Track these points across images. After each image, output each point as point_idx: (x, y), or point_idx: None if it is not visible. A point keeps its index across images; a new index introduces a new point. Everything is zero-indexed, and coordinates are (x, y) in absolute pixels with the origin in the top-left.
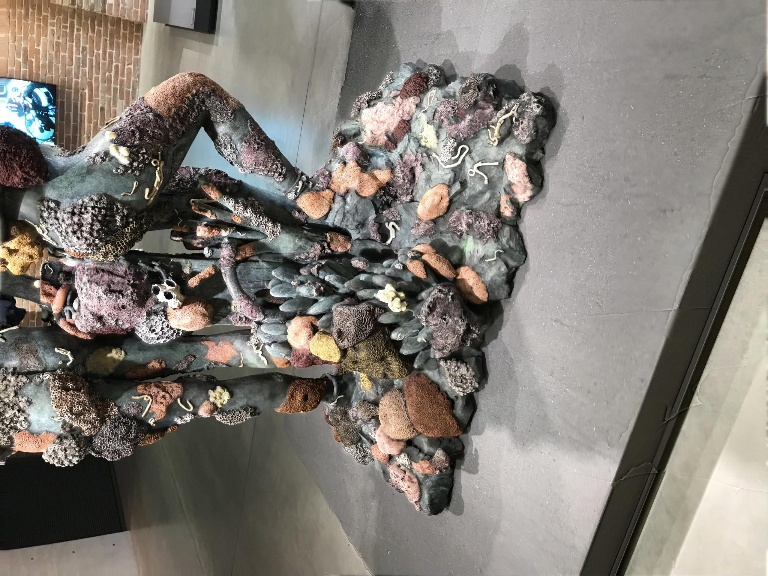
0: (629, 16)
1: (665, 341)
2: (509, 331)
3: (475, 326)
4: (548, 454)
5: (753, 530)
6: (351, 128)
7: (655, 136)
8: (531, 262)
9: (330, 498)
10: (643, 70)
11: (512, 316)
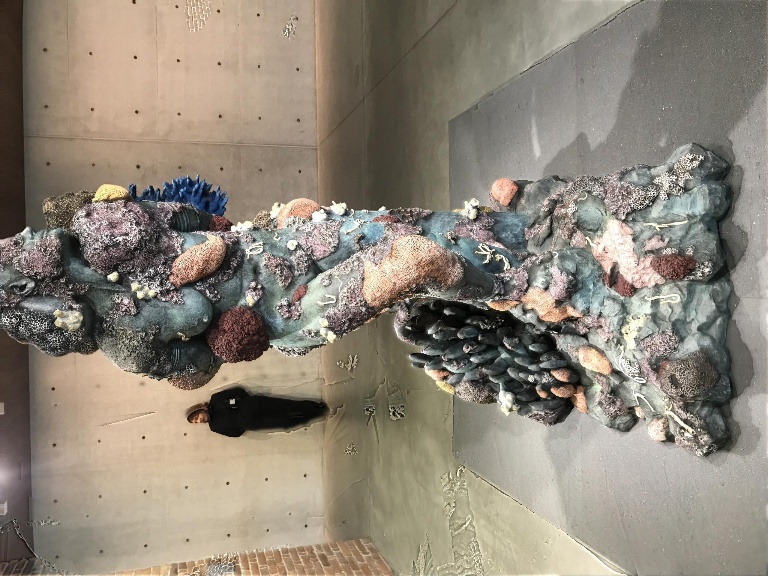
0: None
1: (624, 572)
2: (587, 422)
3: (560, 422)
4: (552, 474)
5: None
6: (591, 222)
7: (722, 567)
8: (626, 438)
9: None
10: (764, 555)
11: (594, 423)
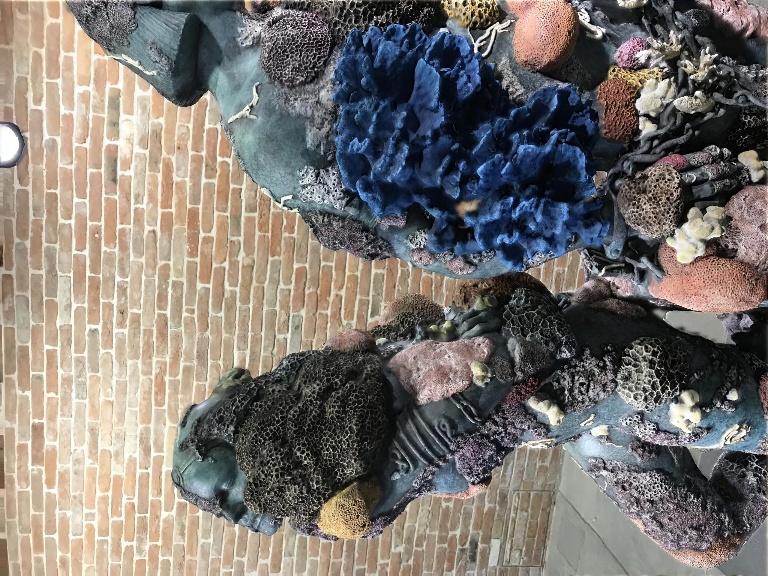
0: (765, 523)
1: None
2: None
3: None
4: None
5: None
6: None
7: None
8: None
9: None
10: None
11: None
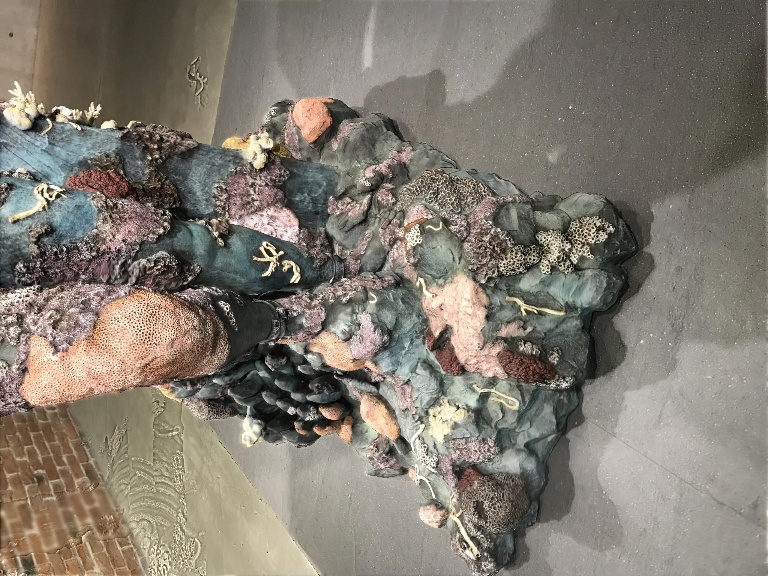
0: None
1: None
2: None
3: None
4: (286, 463)
5: (312, 575)
6: (437, 267)
7: None
8: (386, 481)
9: (223, 102)
10: None
11: None
